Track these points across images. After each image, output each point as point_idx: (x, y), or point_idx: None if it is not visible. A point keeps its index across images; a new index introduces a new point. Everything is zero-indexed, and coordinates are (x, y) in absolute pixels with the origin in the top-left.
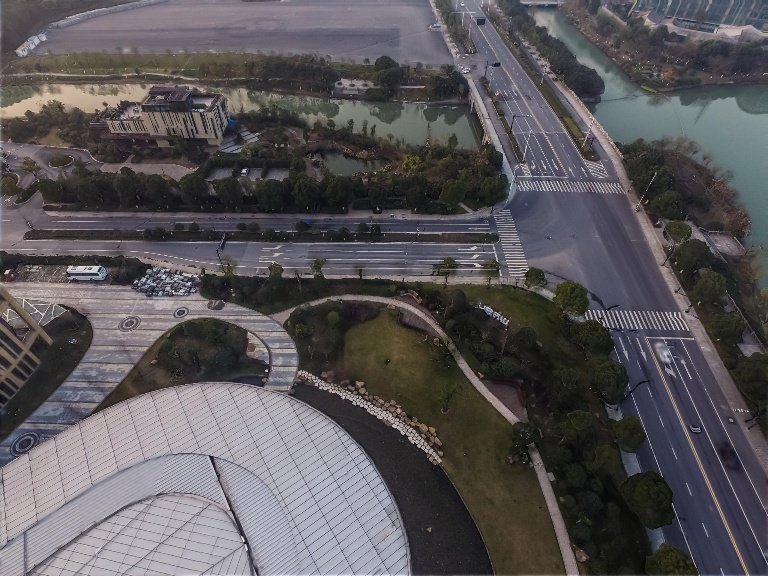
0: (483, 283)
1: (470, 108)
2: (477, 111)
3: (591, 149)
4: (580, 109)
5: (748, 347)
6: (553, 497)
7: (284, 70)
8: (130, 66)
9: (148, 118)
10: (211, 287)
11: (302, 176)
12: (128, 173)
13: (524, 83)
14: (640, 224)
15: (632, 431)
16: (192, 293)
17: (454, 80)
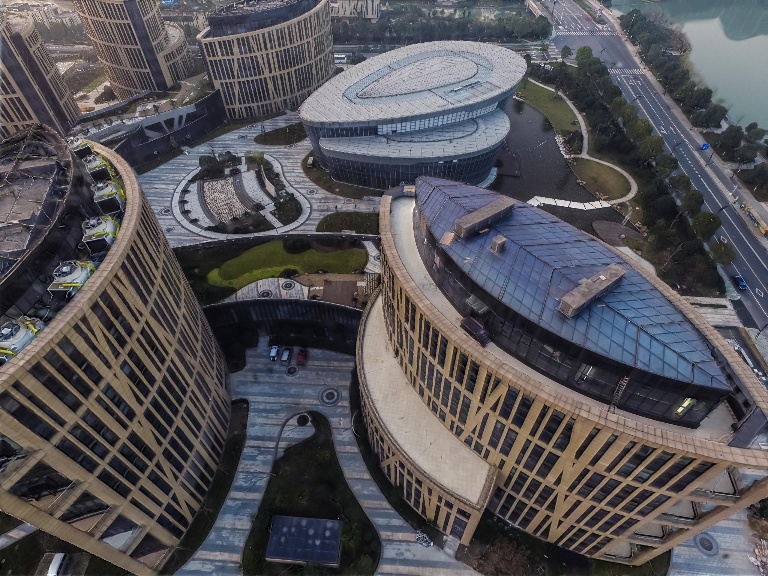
0: (539, 62)
1: (526, 9)
2: (531, 7)
3: (601, 19)
4: (597, 5)
5: None
6: (573, 105)
7: None
8: None
9: (341, 5)
10: None
11: None
12: (339, 27)
13: None
14: (626, 45)
15: (607, 79)
16: None
17: None
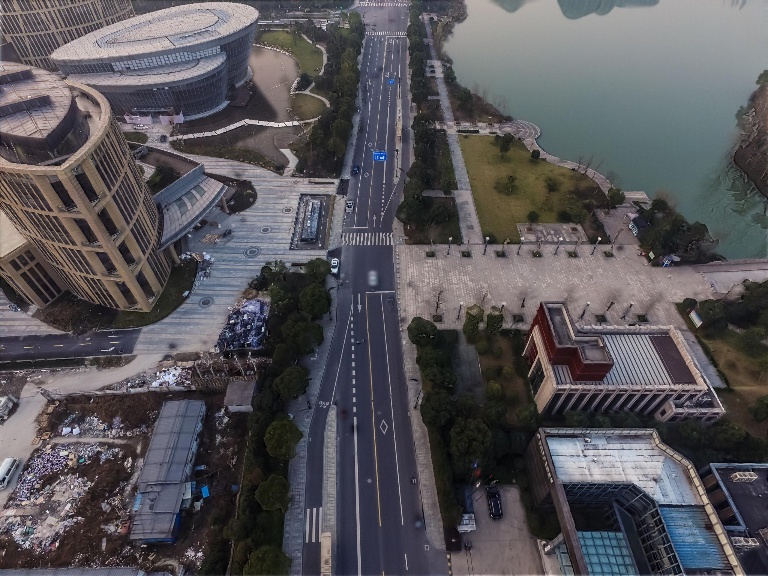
0: None
1: None
2: None
3: None
4: None
5: (428, 39)
6: (326, 57)
7: None
8: None
9: None
10: None
11: None
12: None
13: None
14: None
15: None
16: None
17: None
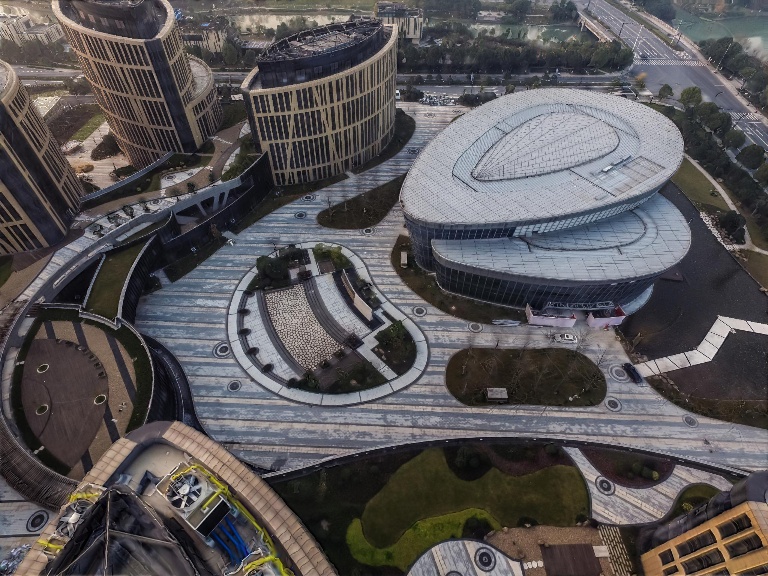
0: None
1: (580, 28)
2: (589, 27)
3: (677, 44)
4: (662, 26)
5: None
6: (700, 166)
7: (443, 2)
8: (318, 3)
9: None
10: (470, 100)
11: (499, 50)
12: None
13: (616, 13)
14: (719, 79)
15: (740, 134)
16: (457, 105)
17: (569, 7)
